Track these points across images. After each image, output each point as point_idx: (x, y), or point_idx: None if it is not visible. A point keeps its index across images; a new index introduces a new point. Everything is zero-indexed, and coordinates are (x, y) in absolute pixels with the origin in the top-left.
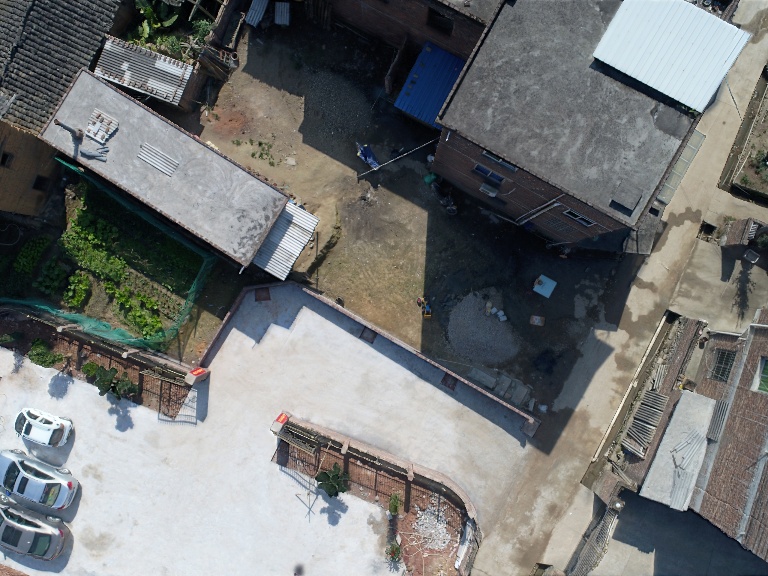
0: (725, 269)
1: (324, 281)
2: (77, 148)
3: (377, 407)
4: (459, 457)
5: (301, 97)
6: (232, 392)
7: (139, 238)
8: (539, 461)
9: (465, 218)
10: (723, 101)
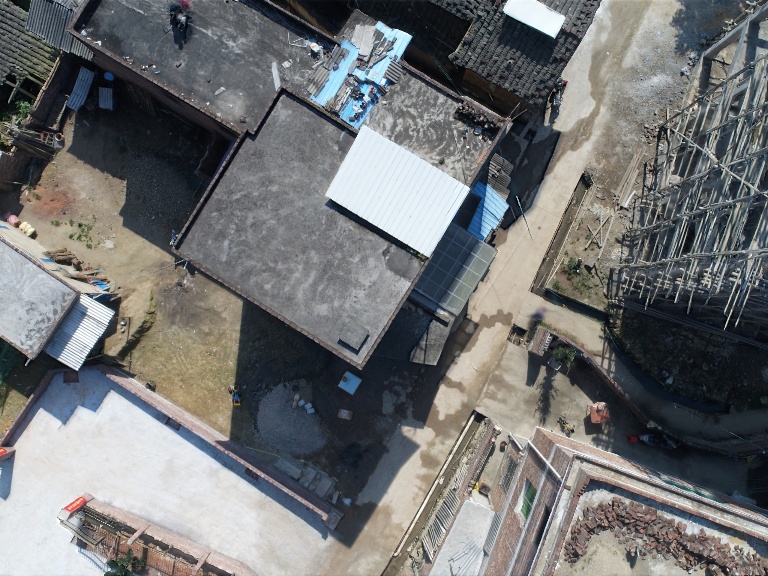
0: (530, 374)
1: (137, 364)
2: None
3: (180, 493)
4: (259, 546)
5: (123, 181)
6: (36, 472)
7: None
8: (340, 553)
9: None
10: (539, 206)
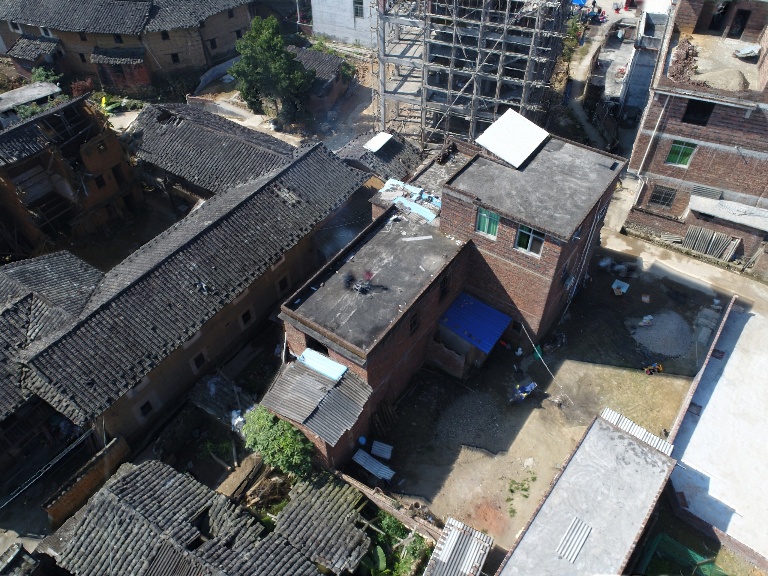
0: None
1: None
2: None
3: (763, 410)
4: None
5: (462, 448)
6: None
7: None
8: (762, 307)
9: (569, 334)
10: None
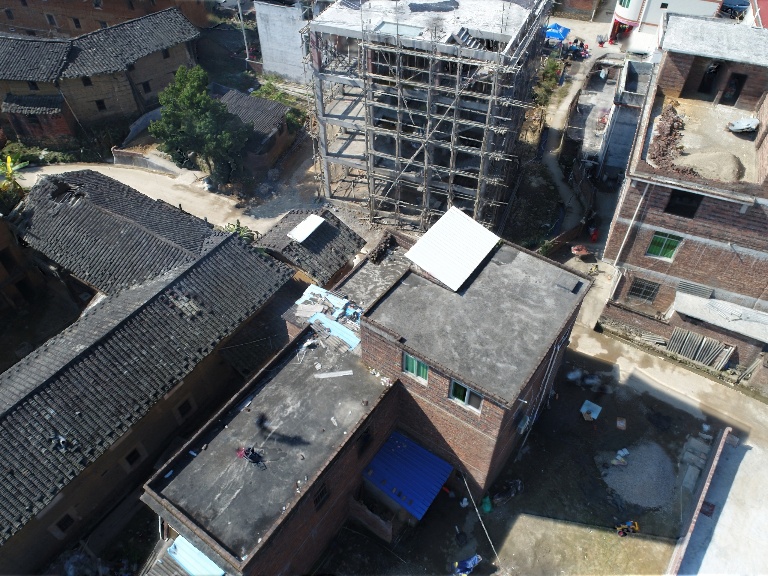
0: None
1: None
2: None
3: None
4: None
5: None
6: None
7: None
8: (760, 436)
9: (526, 476)
10: None
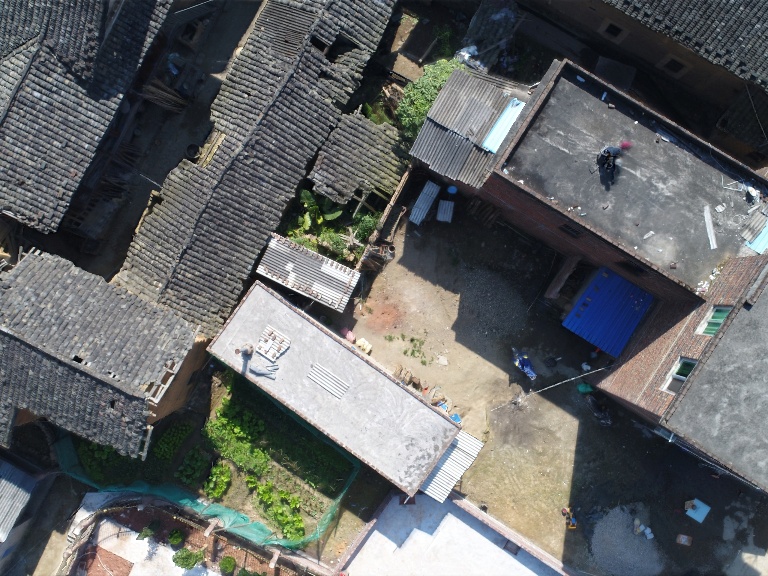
0: None
1: (468, 484)
2: (246, 364)
3: None
4: None
5: (457, 294)
6: None
7: (284, 431)
8: None
9: (617, 430)
10: None
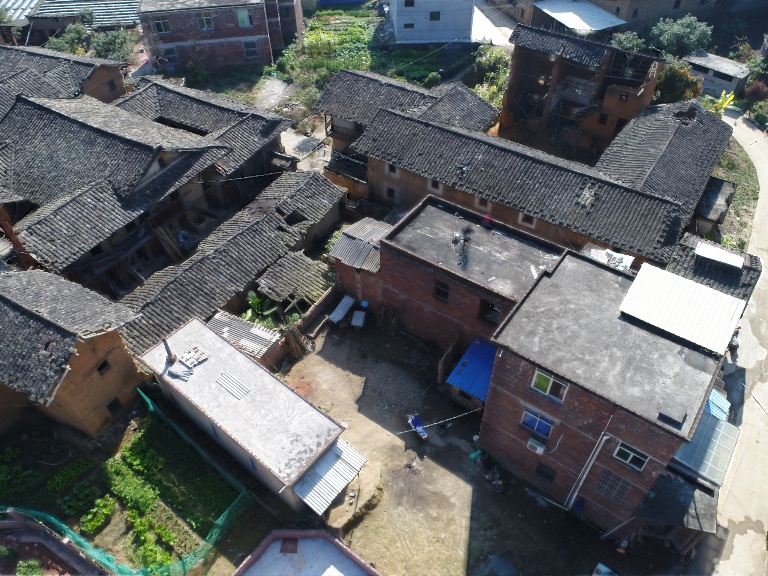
0: None
1: (357, 545)
2: (167, 369)
3: None
4: None
5: (363, 378)
6: None
7: (181, 472)
8: None
9: (511, 497)
10: (750, 423)
